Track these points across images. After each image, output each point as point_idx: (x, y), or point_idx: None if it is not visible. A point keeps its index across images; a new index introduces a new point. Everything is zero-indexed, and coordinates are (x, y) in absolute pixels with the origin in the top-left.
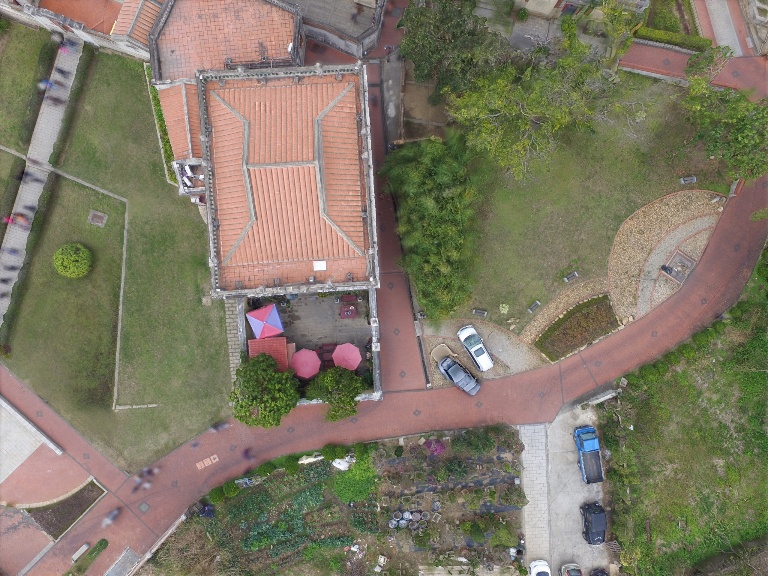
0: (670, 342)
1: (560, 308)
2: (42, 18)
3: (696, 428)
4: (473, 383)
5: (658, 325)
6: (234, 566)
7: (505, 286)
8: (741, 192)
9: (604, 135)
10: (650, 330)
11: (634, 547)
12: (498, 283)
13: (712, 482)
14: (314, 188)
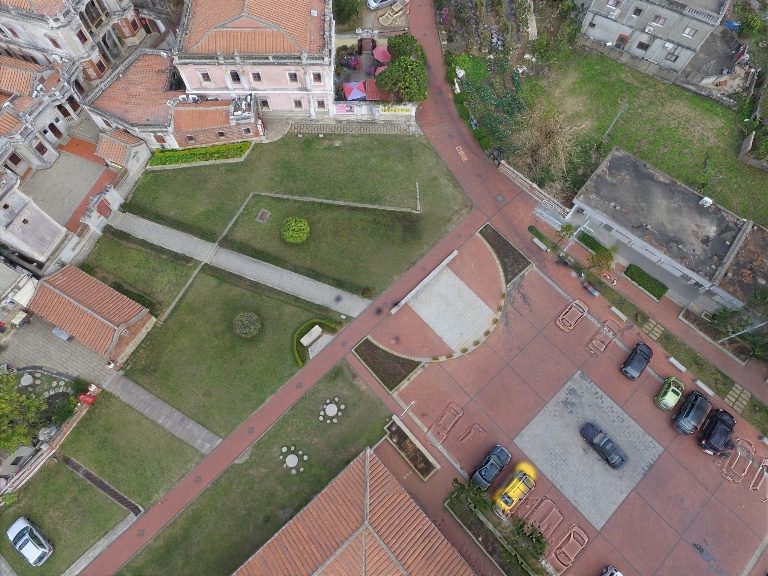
0: None
1: None
2: (94, 217)
3: None
4: None
5: None
6: None
7: None
8: None
9: None
10: None
11: None
12: None
13: None
14: None
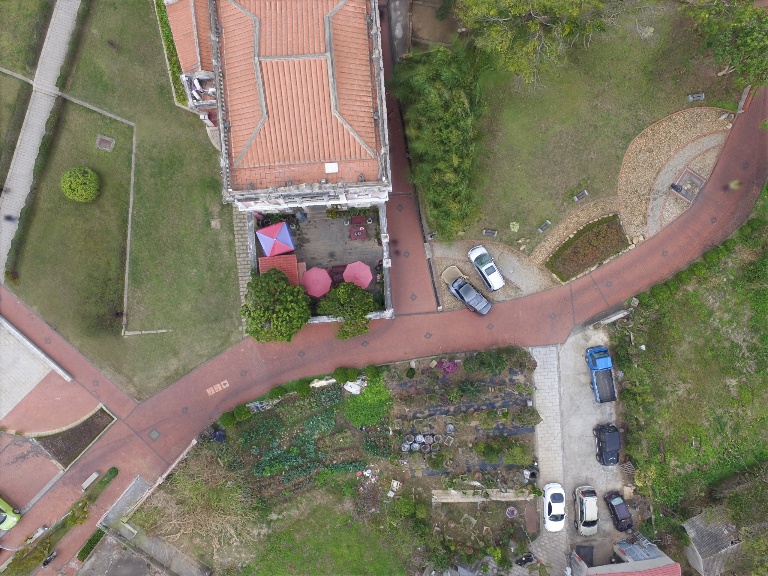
0: (681, 261)
1: (570, 228)
2: None
3: (708, 347)
4: (484, 302)
5: (668, 244)
6: (246, 492)
7: (515, 206)
8: (749, 108)
9: (612, 53)
10: (660, 249)
11: (648, 465)
12: (508, 203)
13: (725, 402)
14: (326, 83)
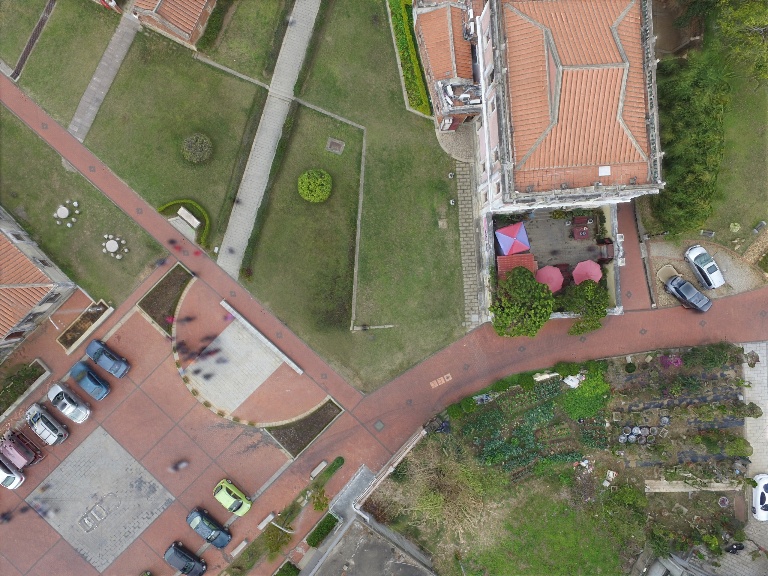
0: None
1: None
2: None
3: None
4: (706, 299)
5: None
6: None
7: (731, 207)
8: None
9: None
10: None
11: None
12: (724, 204)
13: None
14: (617, 91)
